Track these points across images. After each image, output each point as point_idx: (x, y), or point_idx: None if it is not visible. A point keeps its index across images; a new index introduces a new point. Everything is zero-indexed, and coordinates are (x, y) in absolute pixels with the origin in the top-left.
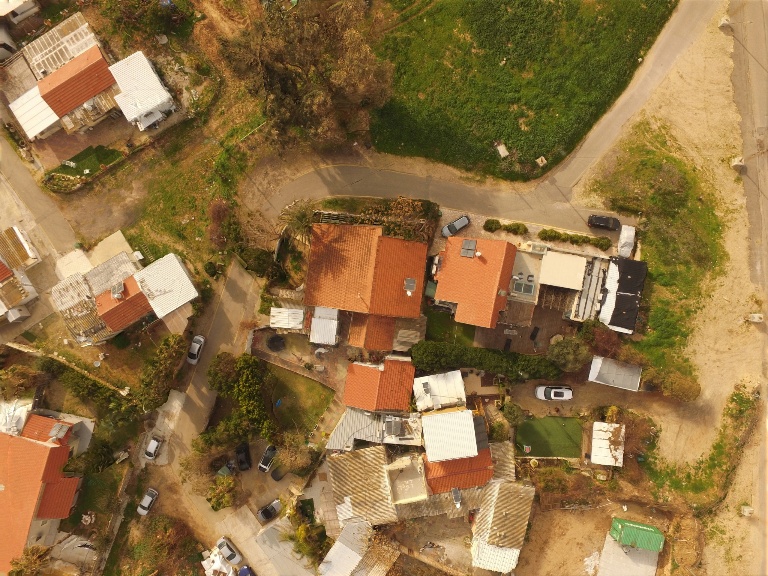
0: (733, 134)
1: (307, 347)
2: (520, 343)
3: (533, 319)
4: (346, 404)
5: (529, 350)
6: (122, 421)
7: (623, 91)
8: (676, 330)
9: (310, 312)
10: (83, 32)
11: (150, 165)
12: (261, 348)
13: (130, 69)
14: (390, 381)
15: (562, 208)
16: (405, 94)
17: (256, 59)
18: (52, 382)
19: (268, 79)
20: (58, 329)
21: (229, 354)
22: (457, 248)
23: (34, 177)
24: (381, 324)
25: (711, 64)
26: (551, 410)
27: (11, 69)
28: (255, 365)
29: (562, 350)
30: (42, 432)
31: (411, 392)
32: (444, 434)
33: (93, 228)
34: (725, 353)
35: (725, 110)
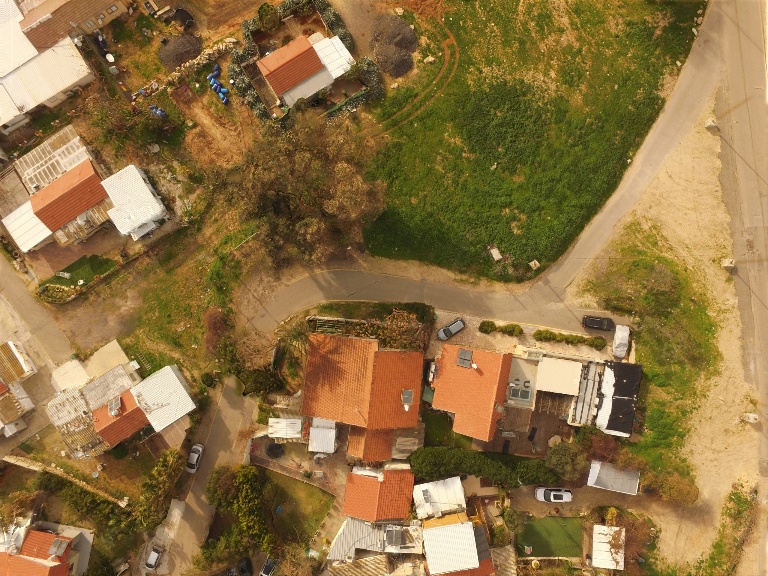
0: (723, 234)
1: (306, 453)
2: (518, 444)
3: (531, 419)
4: (346, 514)
5: (527, 451)
6: (122, 534)
7: (613, 192)
8: (673, 431)
9: (308, 422)
10: (75, 145)
11: (144, 274)
12: (260, 454)
13: (122, 183)
14: (390, 491)
15: (556, 308)
16: (397, 199)
17: (248, 166)
18: (50, 497)
19: (261, 204)
20: (55, 440)
21: (228, 468)
22: (453, 357)
23: (28, 288)
24: (379, 435)
25: (699, 164)
26: (551, 510)
27: (3, 184)
28: (254, 478)
29: (560, 459)
30: (41, 549)
31: (411, 499)
32: (445, 547)
33: (88, 338)
34: (722, 452)
35: (714, 210)
